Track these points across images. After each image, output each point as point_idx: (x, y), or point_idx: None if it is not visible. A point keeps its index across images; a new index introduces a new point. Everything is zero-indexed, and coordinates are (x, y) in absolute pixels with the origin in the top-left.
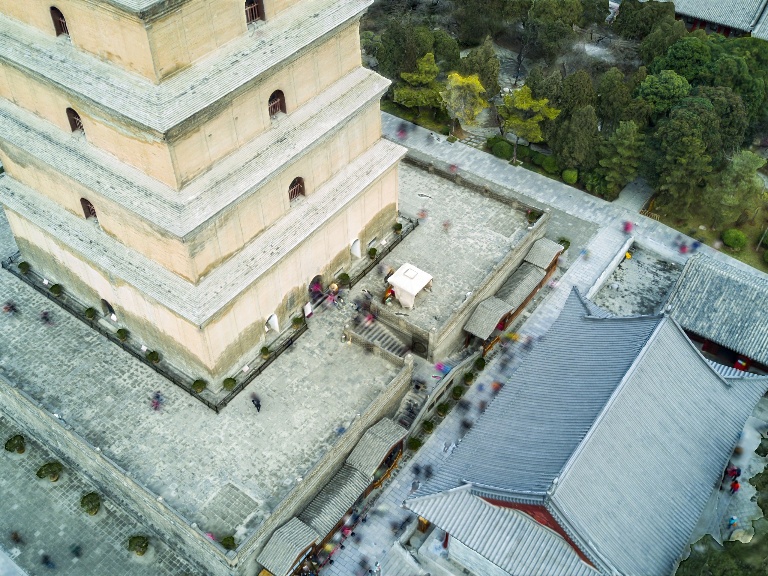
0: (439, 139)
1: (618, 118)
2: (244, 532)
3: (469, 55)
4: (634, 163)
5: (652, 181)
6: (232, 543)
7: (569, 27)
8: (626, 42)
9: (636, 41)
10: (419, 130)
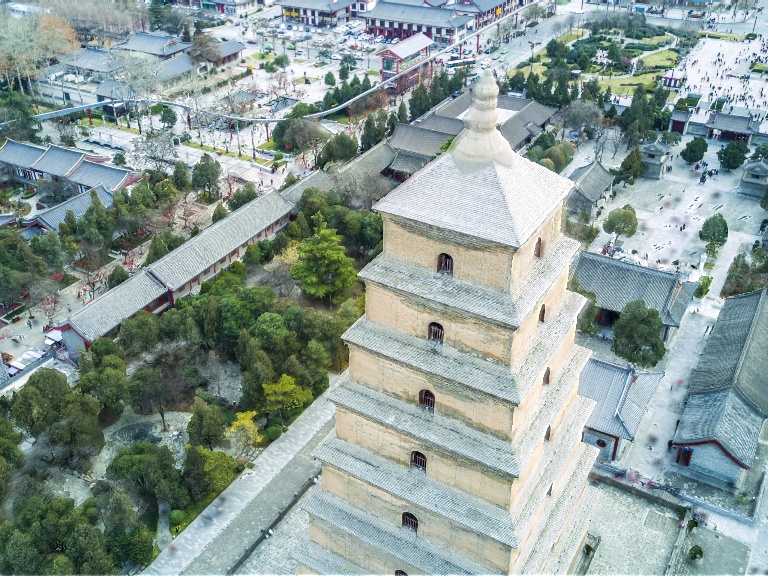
0: (250, 473)
1: (290, 352)
2: (669, 514)
3: (195, 421)
4: (326, 356)
5: (332, 356)
6: (682, 510)
7: (150, 368)
8: (162, 347)
9: (161, 343)
10: (235, 487)
